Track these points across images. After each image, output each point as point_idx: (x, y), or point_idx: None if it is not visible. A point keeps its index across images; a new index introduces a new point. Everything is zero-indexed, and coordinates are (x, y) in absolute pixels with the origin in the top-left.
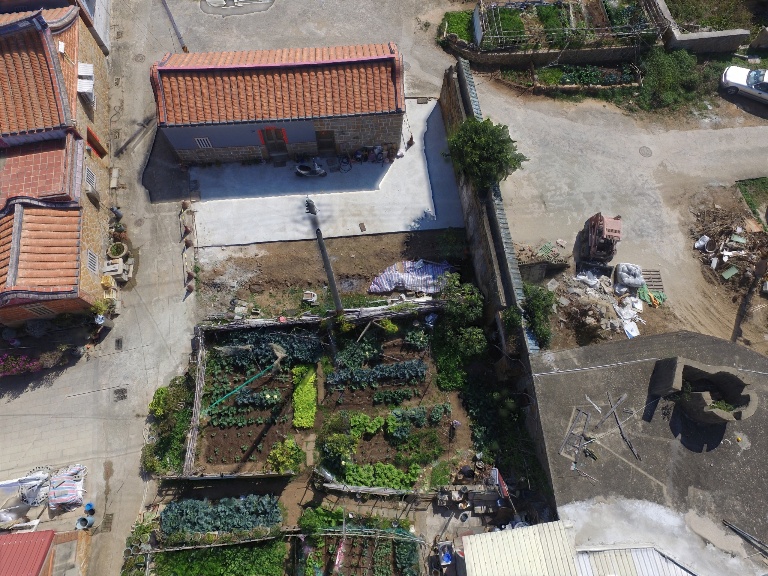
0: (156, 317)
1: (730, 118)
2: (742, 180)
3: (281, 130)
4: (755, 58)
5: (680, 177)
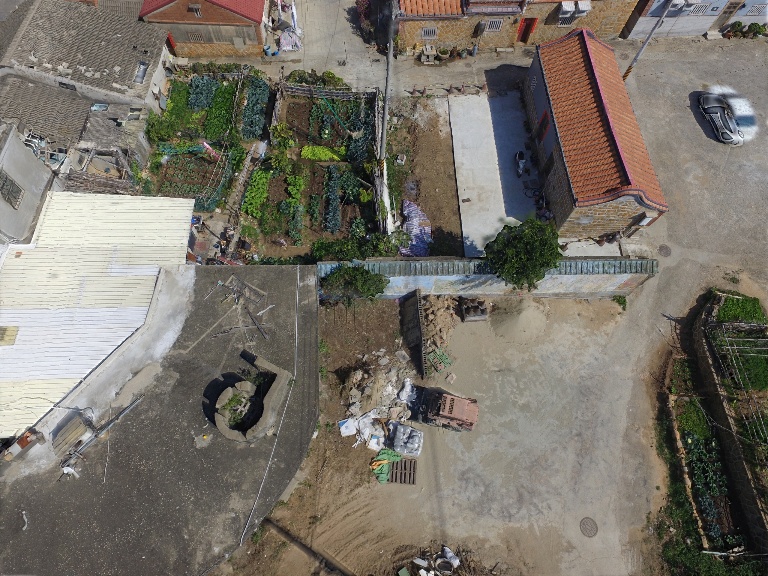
0: (393, 77)
1: None
2: None
3: None
4: None
5: (552, 567)
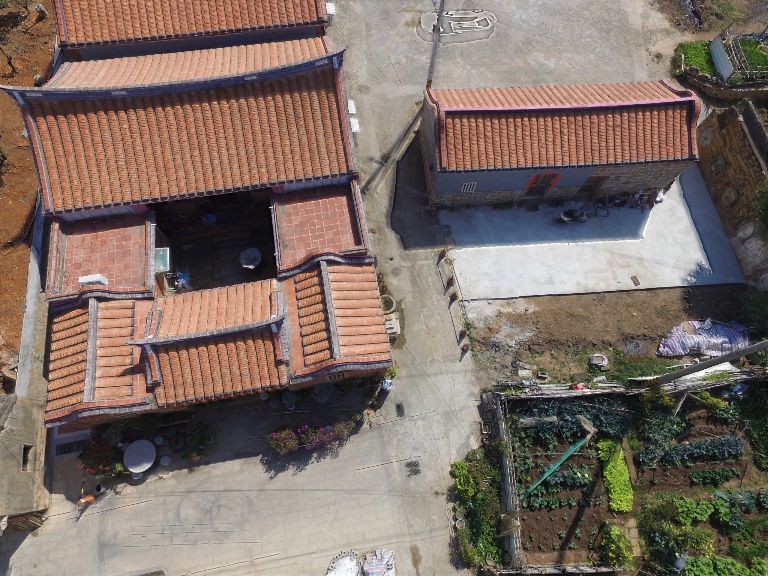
0: (435, 380)
1: None
2: None
3: (556, 175)
4: None
5: None
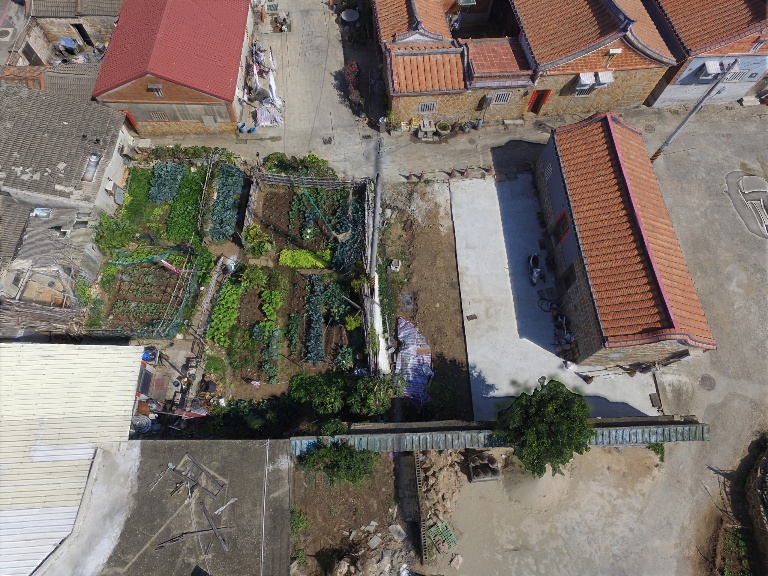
0: (386, 157)
1: None
2: None
3: (568, 229)
4: None
5: None
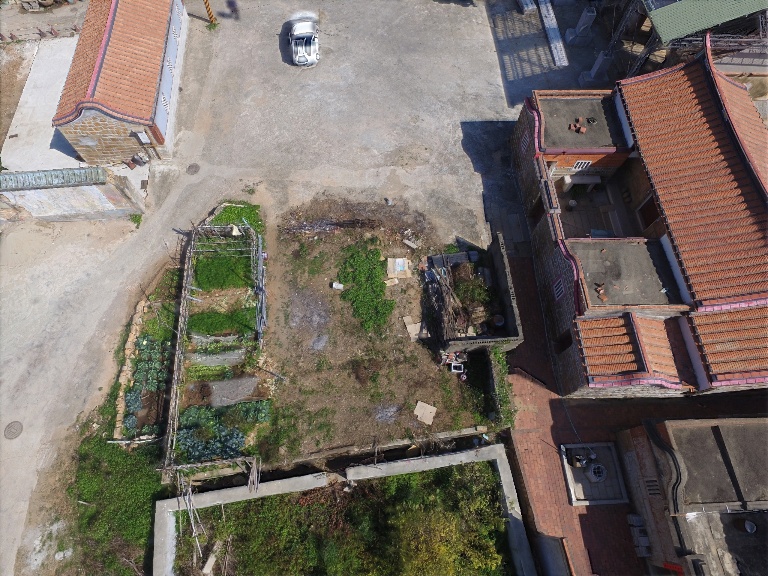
0: None
1: None
2: None
3: None
4: None
5: None
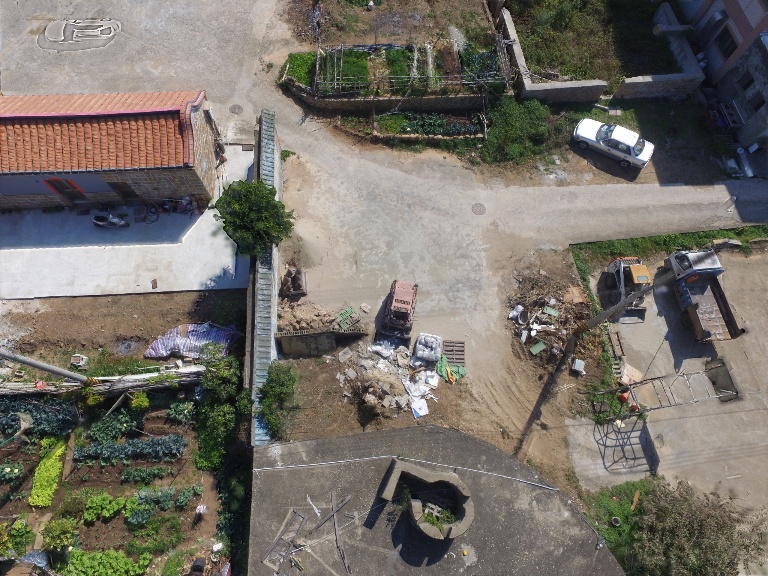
0: None
1: (577, 174)
2: (577, 243)
3: None
4: (617, 109)
5: (510, 238)
